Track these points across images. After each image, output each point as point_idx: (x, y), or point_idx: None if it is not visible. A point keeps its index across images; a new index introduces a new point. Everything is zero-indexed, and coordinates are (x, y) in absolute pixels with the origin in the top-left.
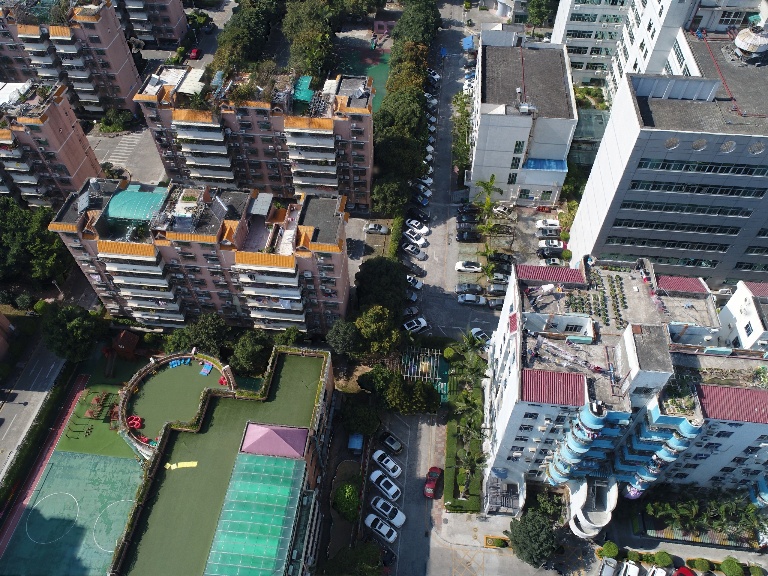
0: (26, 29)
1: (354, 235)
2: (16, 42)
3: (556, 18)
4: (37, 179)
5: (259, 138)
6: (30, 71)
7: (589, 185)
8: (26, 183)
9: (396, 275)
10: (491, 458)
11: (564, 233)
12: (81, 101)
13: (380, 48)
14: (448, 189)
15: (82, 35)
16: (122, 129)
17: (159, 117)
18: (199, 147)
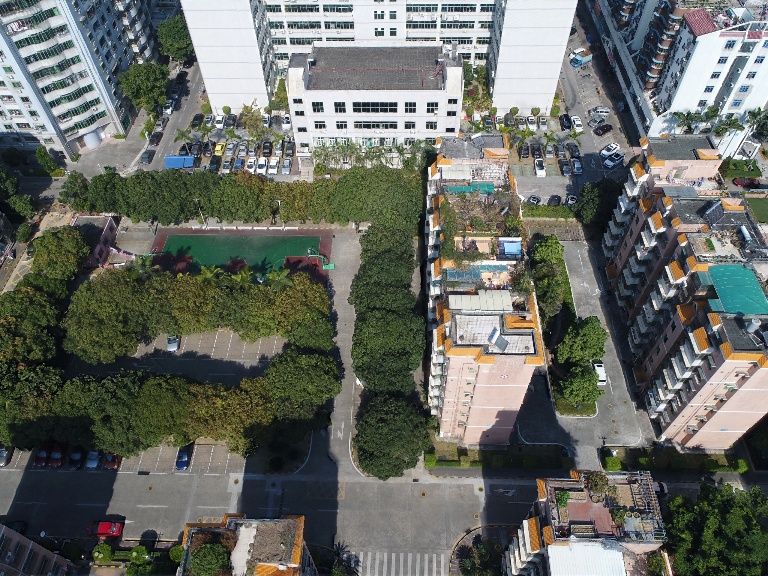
0: None
1: None
2: None
3: (203, 68)
4: None
5: None
6: None
7: (508, 52)
8: None
9: (612, 180)
10: (744, 131)
11: (493, 110)
12: None
13: None
14: None
15: None
16: None
17: None
18: None
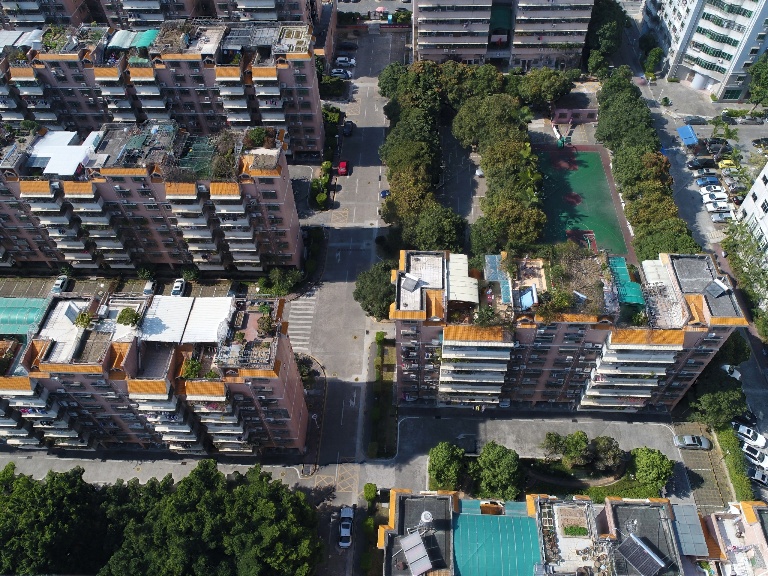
0: (177, 188)
1: (664, 453)
2: (158, 201)
3: None
4: (242, 426)
5: (556, 349)
6: (170, 231)
7: None
8: (227, 433)
9: None
10: None
11: None
12: (236, 262)
13: (570, 144)
14: (756, 364)
15: (252, 190)
16: (288, 292)
17: (418, 333)
18: (467, 364)
